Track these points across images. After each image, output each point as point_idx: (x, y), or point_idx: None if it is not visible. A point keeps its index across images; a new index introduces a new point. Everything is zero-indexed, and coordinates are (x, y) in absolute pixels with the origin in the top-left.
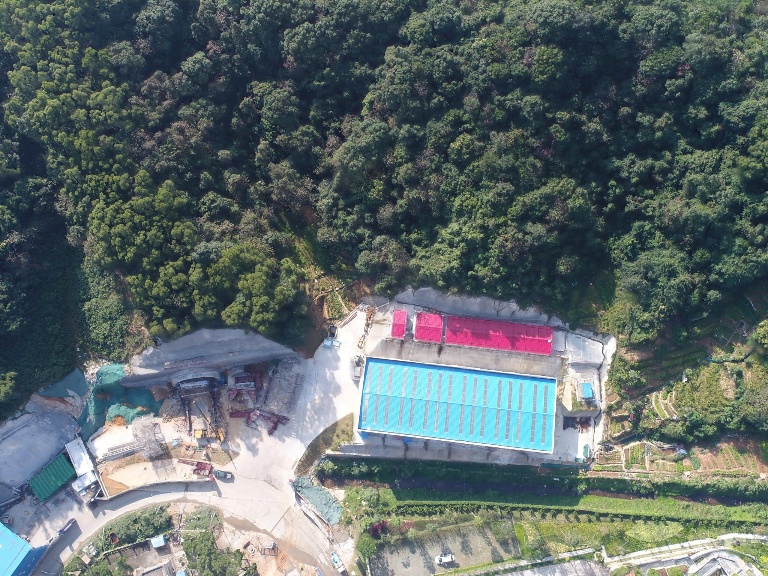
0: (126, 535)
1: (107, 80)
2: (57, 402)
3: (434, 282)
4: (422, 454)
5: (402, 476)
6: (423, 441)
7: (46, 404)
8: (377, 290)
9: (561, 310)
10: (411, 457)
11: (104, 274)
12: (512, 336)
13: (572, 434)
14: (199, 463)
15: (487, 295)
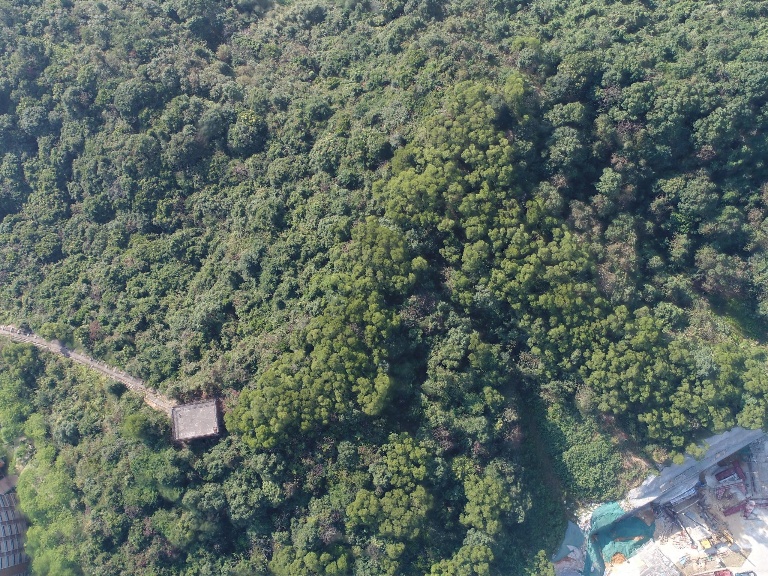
0: None
1: (554, 228)
2: (563, 562)
3: None
4: None
5: None
6: None
7: (558, 569)
8: None
9: None
10: None
11: (583, 419)
12: None
13: None
14: (716, 573)
15: None
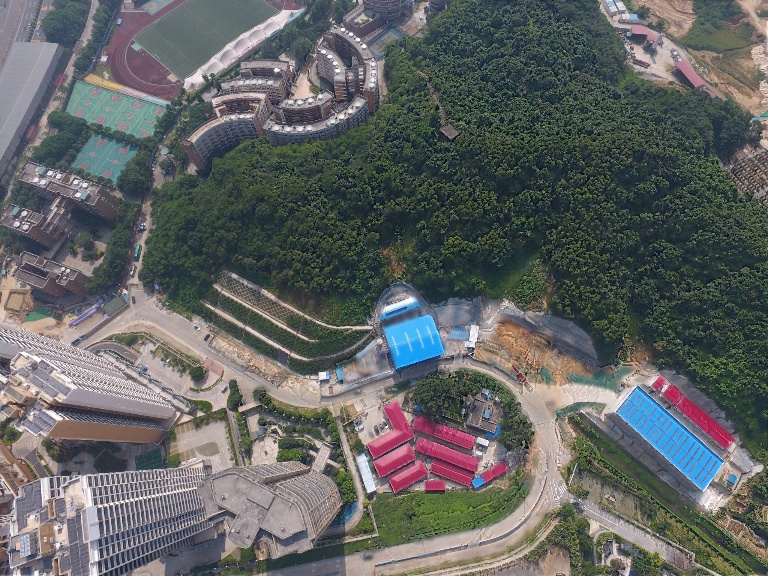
0: (475, 378)
1: (612, 200)
2: (482, 306)
3: (694, 377)
4: (627, 446)
5: (608, 448)
6: (642, 439)
7: (479, 303)
8: (661, 361)
9: (744, 434)
10: (620, 443)
11: (545, 271)
12: (711, 427)
13: (708, 493)
14: (521, 374)
15: (715, 400)
